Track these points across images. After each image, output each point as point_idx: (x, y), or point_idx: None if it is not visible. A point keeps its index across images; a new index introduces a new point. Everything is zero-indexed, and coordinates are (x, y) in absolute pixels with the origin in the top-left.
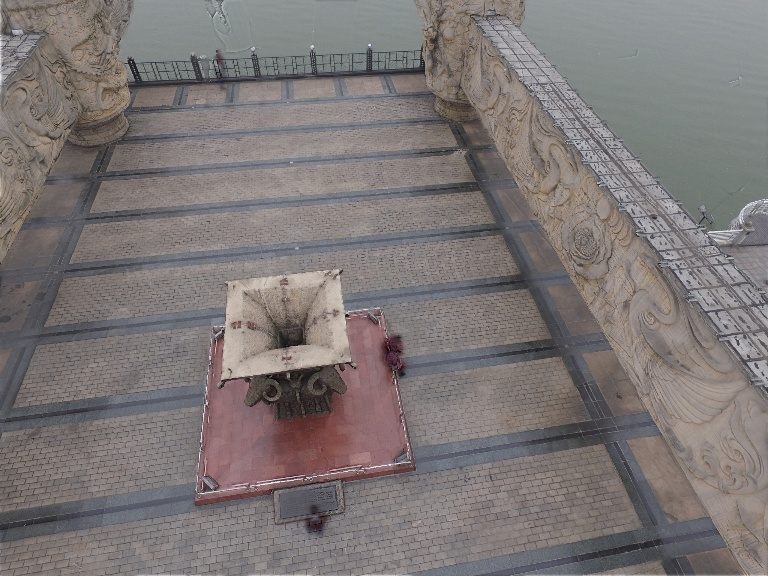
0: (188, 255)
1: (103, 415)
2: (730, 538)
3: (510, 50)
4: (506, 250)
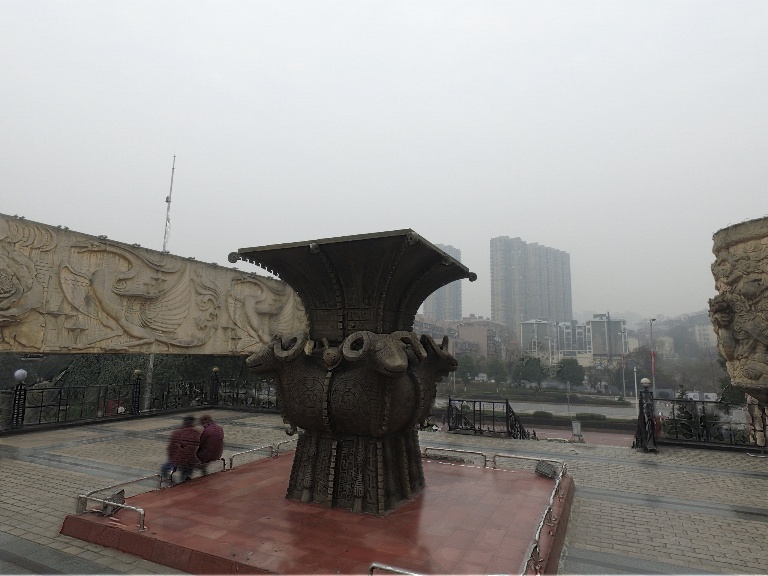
0: None
1: None
2: (230, 348)
3: None
4: None
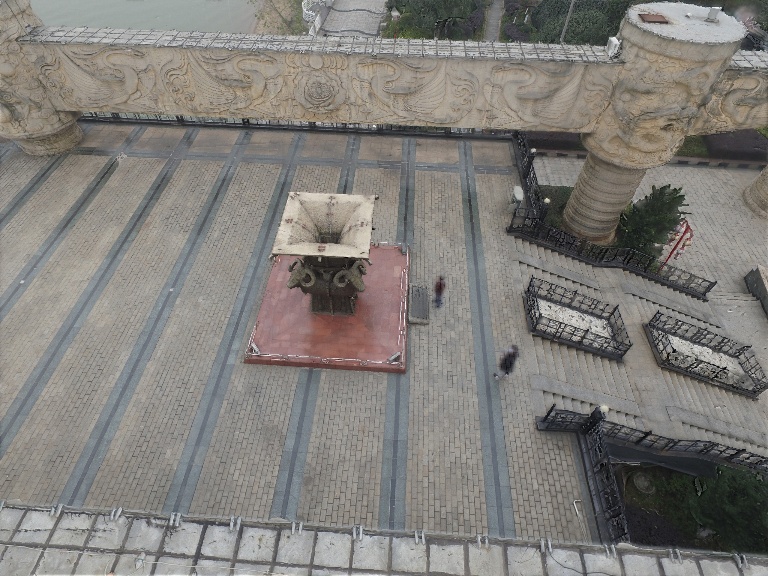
0: (118, 389)
1: (303, 454)
2: (484, 124)
3: (106, 39)
4: (256, 164)
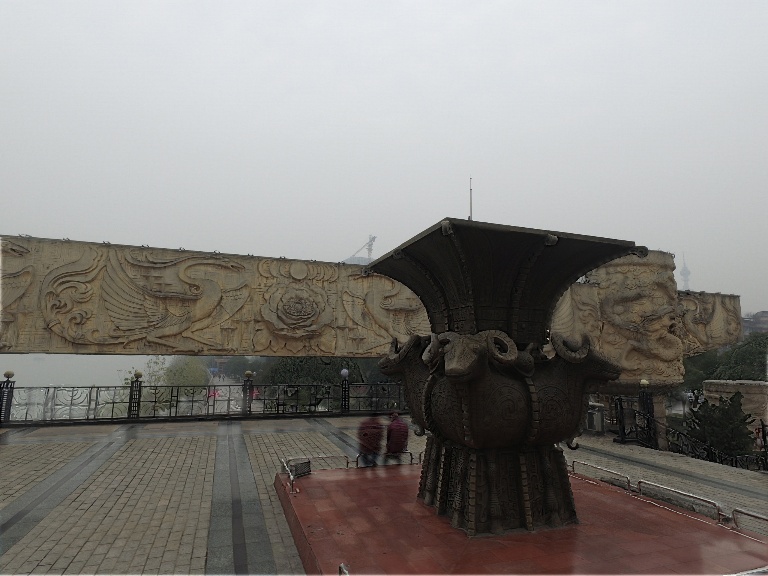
0: None
1: None
2: None
3: None
4: (166, 438)
